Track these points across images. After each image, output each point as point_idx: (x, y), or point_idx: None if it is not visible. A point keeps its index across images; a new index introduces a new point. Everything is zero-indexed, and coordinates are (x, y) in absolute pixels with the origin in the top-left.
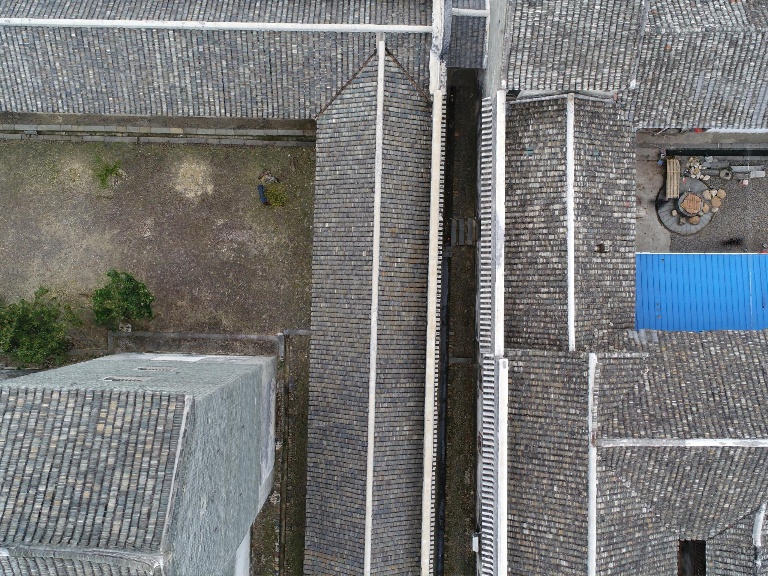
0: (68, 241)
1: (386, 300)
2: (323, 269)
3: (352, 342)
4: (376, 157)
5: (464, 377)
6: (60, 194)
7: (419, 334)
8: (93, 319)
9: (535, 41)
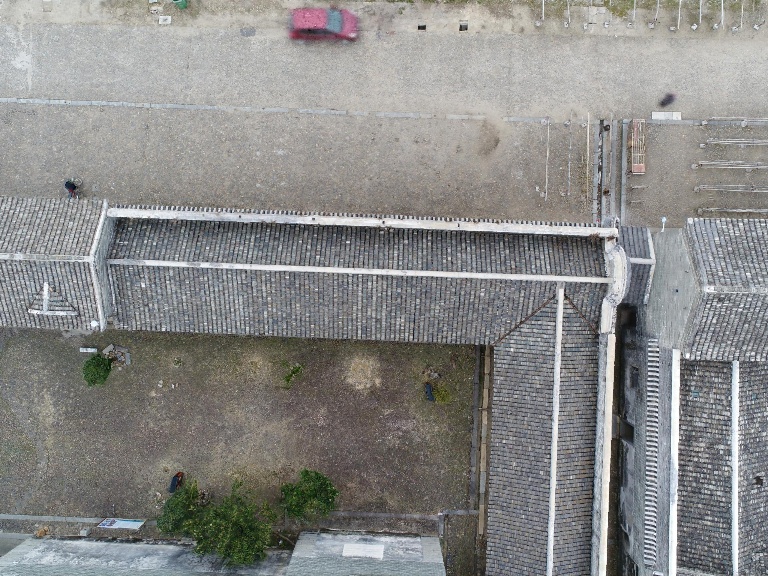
0: (249, 427)
1: (560, 514)
2: (500, 480)
3: (529, 549)
4: (555, 390)
5: (607, 556)
6: (242, 384)
7: (585, 540)
8: (271, 498)
9: (719, 325)
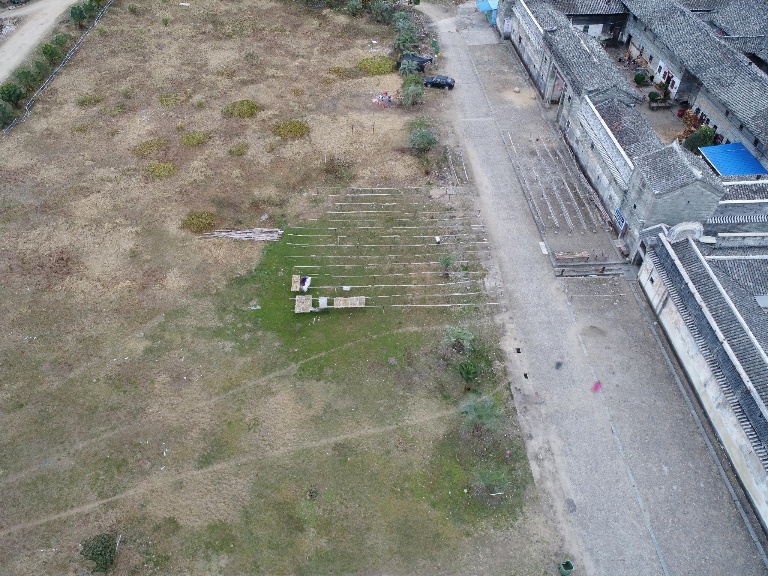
0: None
1: None
2: None
3: None
4: (767, 257)
5: None
6: None
7: None
8: None
9: None
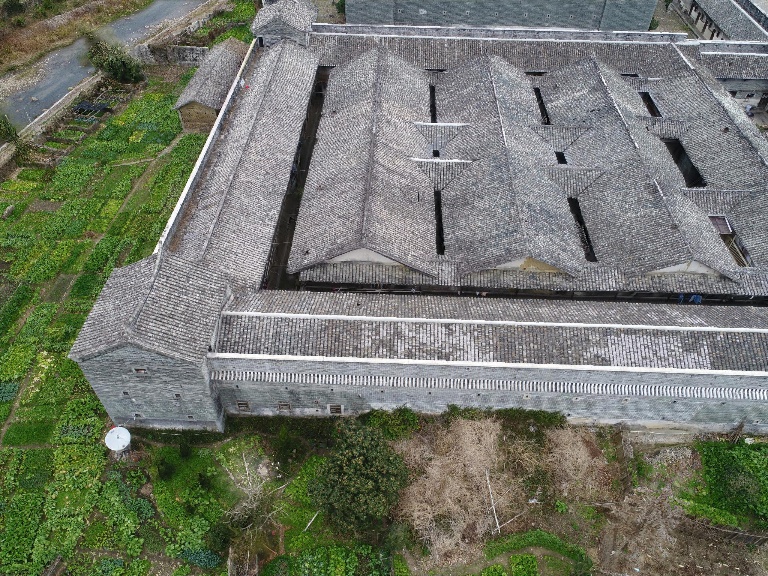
0: None
1: None
2: None
3: None
4: None
5: None
6: None
7: None
8: None
9: None
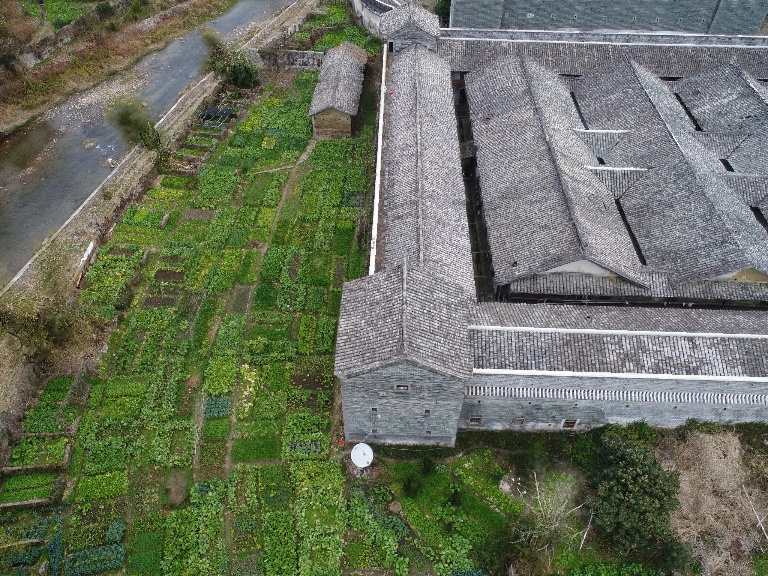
0: None
1: None
2: None
3: None
4: None
5: None
6: None
7: None
8: None
9: None
